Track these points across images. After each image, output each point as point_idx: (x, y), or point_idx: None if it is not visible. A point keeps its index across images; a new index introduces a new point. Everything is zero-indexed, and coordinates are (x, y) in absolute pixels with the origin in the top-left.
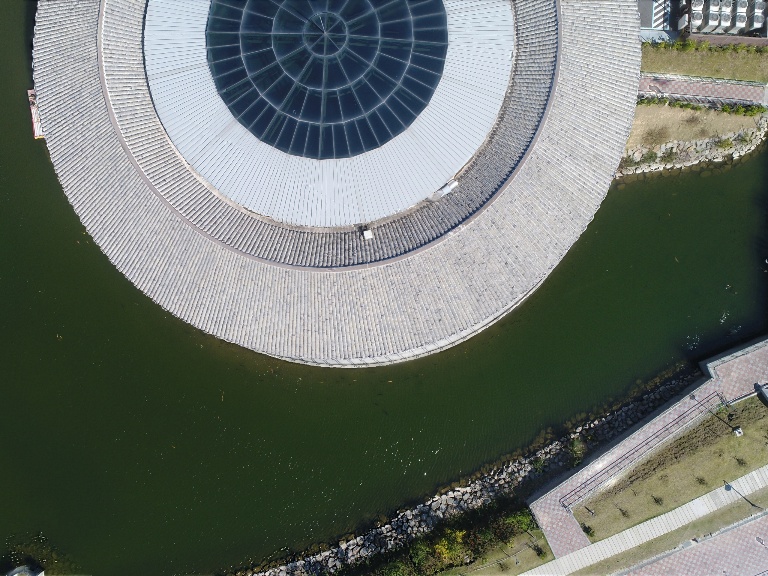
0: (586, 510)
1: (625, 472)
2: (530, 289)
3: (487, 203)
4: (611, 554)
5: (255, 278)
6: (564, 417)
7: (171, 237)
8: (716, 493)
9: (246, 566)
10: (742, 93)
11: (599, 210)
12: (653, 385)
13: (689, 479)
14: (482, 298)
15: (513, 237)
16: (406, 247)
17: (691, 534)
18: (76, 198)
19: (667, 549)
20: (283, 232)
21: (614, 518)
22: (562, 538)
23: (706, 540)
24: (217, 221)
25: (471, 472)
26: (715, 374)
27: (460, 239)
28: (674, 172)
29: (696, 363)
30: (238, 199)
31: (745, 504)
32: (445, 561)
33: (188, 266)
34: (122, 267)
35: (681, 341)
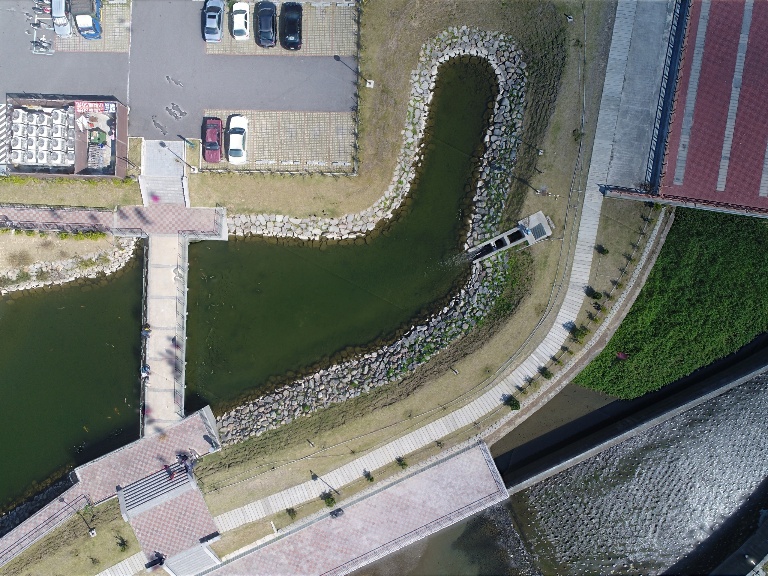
0: None
1: None
2: None
3: None
4: None
5: None
6: None
7: None
8: None
9: None
10: (91, 218)
11: None
12: (45, 486)
13: None
14: None
15: None
16: None
17: None
18: None
19: None
20: None
21: None
22: None
23: None
24: None
25: None
26: (82, 478)
27: None
28: (55, 288)
29: None
30: None
31: None
32: None
33: None
34: None
35: None
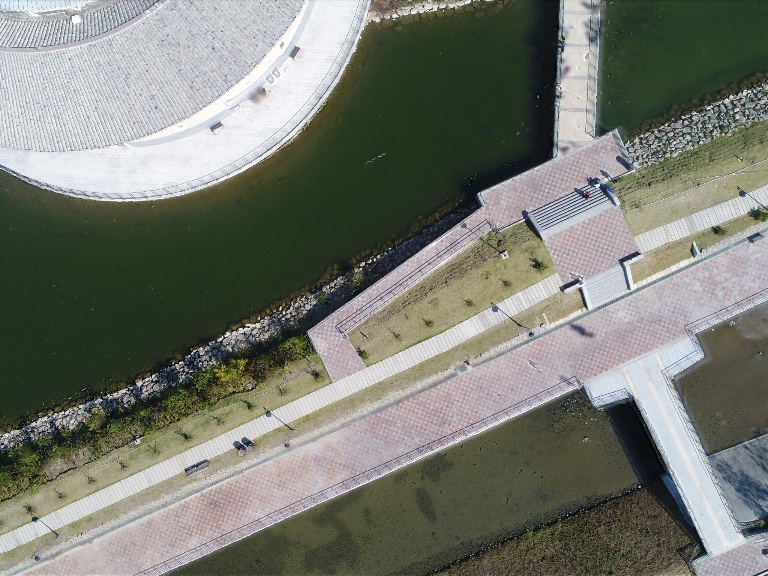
0: (361, 335)
1: (399, 298)
2: (301, 120)
3: None
4: (385, 376)
5: None
6: (350, 254)
7: None
8: (484, 314)
9: (48, 407)
10: None
11: (379, 52)
12: (433, 220)
13: (458, 302)
14: (195, 85)
15: (216, 21)
16: (108, 27)
17: (462, 355)
18: None
19: (439, 371)
20: None
21: (387, 341)
22: (338, 362)
23: (481, 365)
24: None
25: (262, 309)
26: (485, 203)
27: (159, 18)
28: (448, 13)
29: (473, 197)
30: None
31: (512, 324)
32: (229, 389)
33: None
34: None
35: (459, 177)
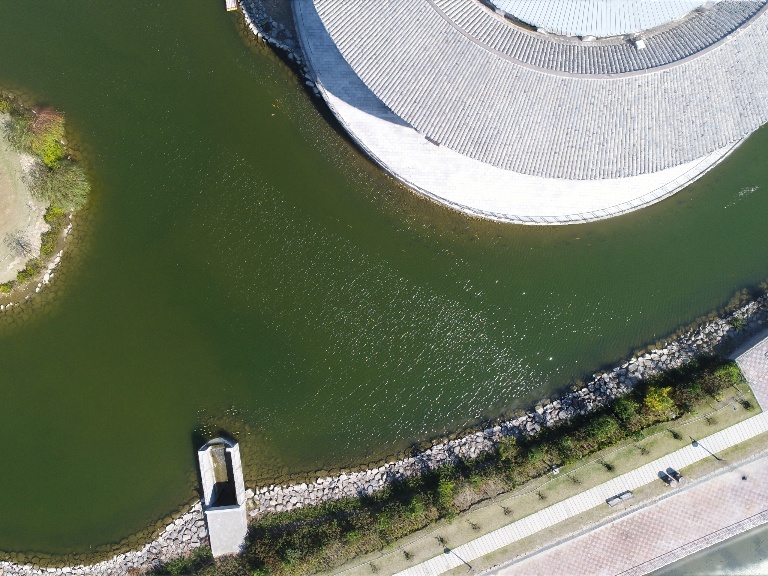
0: None
1: None
2: (736, 142)
3: (765, 6)
4: None
5: (528, 90)
6: (758, 279)
7: (442, 52)
8: None
9: (441, 434)
10: None
11: None
12: None
13: None
14: (745, 112)
15: None
16: (682, 53)
17: None
18: (334, 24)
19: None
20: (553, 45)
21: None
22: None
23: None
24: (490, 33)
25: (666, 335)
26: None
27: (736, 44)
28: None
29: None
30: (513, 10)
31: None
32: (650, 418)
33: (457, 82)
34: (380, 92)
35: None
